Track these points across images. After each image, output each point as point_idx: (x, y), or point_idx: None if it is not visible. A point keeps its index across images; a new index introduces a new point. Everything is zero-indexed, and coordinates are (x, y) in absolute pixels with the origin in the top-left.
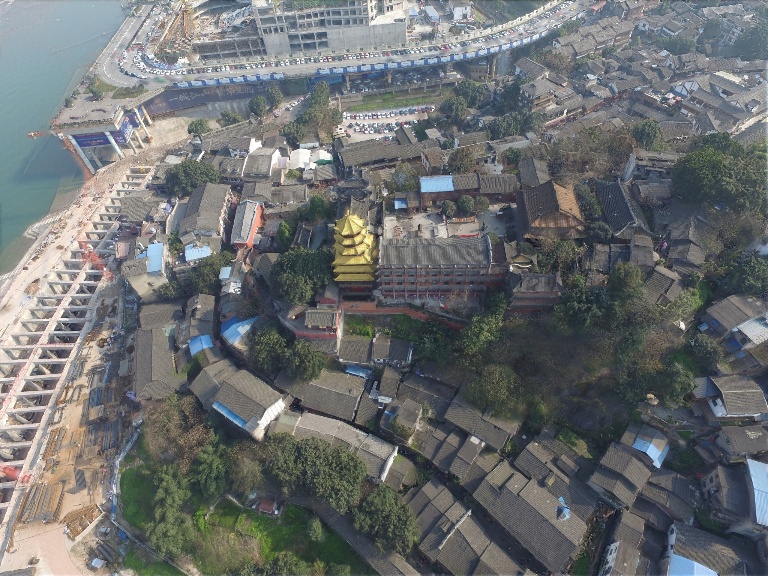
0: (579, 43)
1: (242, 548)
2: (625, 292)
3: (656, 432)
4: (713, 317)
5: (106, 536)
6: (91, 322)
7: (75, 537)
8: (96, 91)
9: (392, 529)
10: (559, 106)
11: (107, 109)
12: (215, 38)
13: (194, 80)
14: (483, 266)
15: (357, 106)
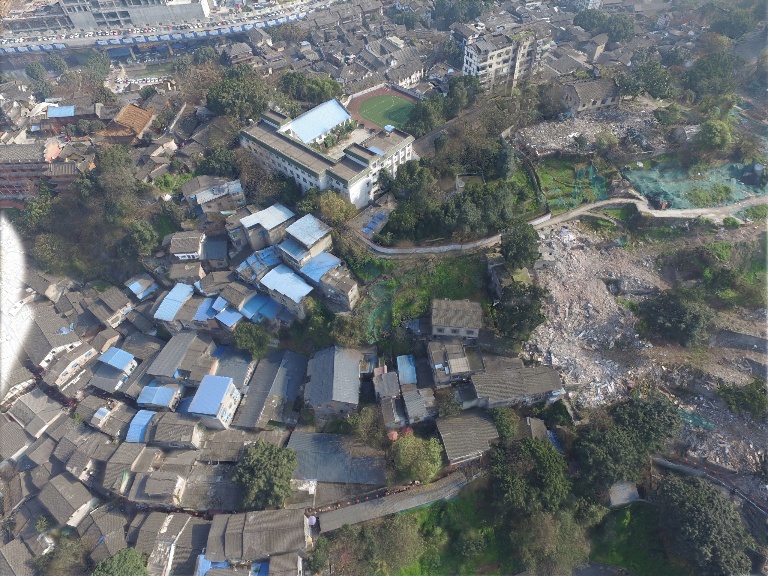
0: (321, 18)
1: None
2: (102, 168)
3: (146, 275)
4: None
5: None
6: None
7: None
8: None
9: None
10: (262, 65)
11: None
12: (25, 16)
13: None
14: (41, 161)
15: (142, 74)
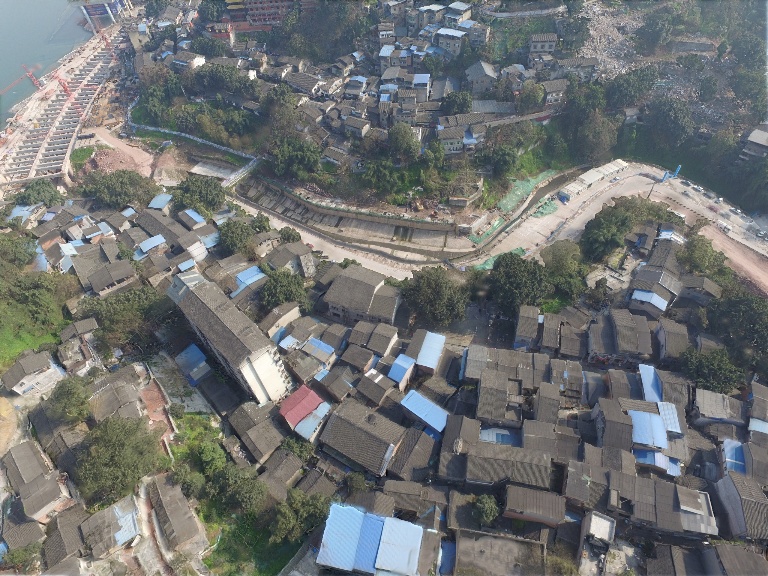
0: None
1: None
2: None
3: (359, 50)
4: (378, 0)
5: (126, 129)
6: None
7: (111, 127)
8: None
9: (248, 84)
10: None
11: None
12: None
13: None
14: None
15: None
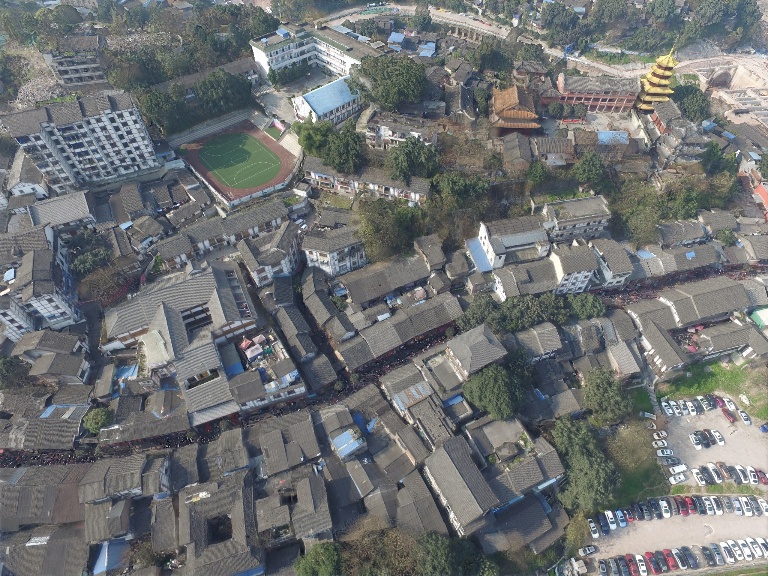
0: None
1: None
2: None
3: None
4: None
5: None
6: None
7: None
8: None
9: None
10: None
11: None
12: None
13: None
14: None
15: None
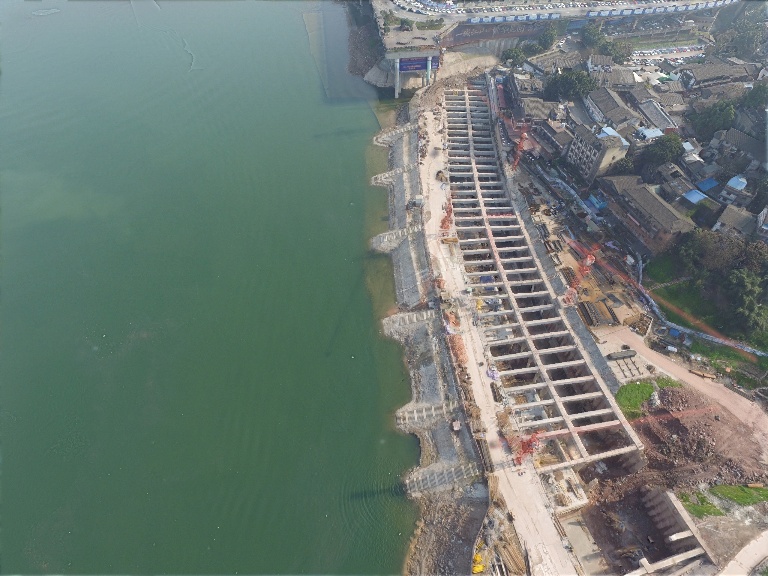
0: None
1: None
2: None
3: None
4: None
5: (664, 333)
6: (517, 201)
7: (646, 332)
8: (409, 22)
9: None
10: None
11: None
12: None
13: (485, 17)
14: None
15: None
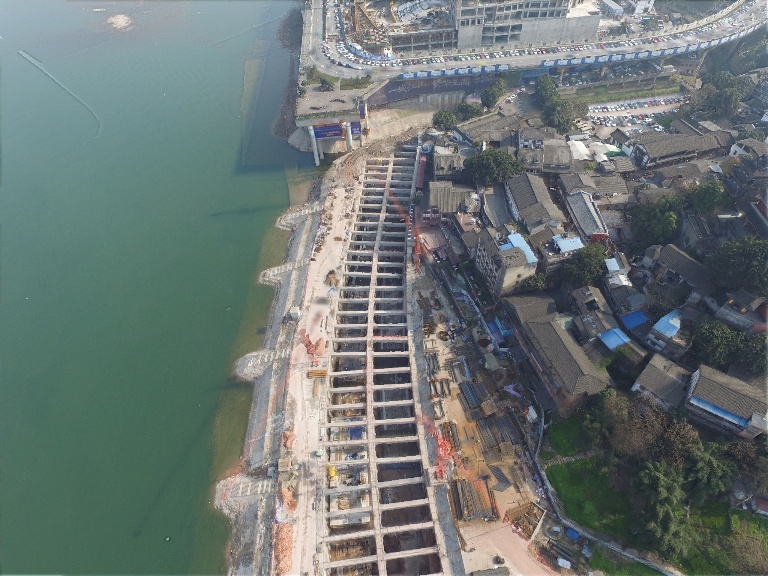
0: None
1: (743, 551)
2: None
3: None
4: None
5: (557, 536)
6: (413, 315)
7: (531, 536)
8: (329, 81)
9: None
10: None
11: (344, 100)
12: (410, 30)
13: (420, 71)
14: None
15: None
